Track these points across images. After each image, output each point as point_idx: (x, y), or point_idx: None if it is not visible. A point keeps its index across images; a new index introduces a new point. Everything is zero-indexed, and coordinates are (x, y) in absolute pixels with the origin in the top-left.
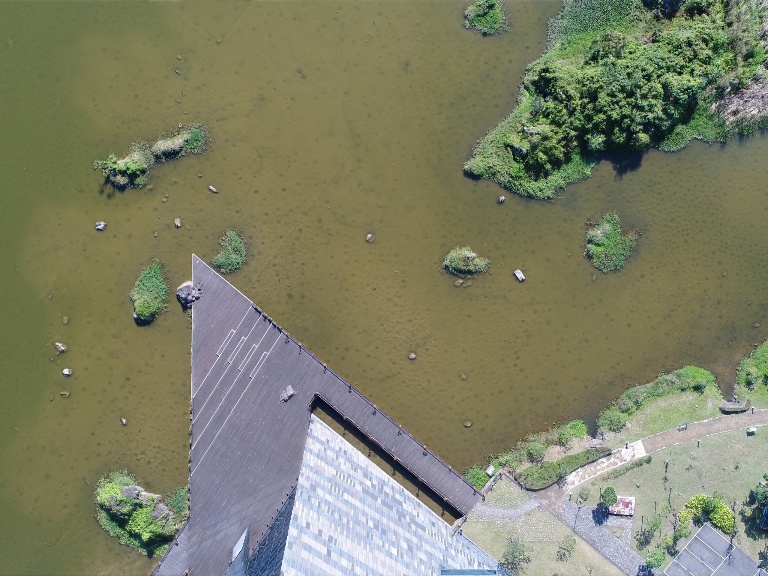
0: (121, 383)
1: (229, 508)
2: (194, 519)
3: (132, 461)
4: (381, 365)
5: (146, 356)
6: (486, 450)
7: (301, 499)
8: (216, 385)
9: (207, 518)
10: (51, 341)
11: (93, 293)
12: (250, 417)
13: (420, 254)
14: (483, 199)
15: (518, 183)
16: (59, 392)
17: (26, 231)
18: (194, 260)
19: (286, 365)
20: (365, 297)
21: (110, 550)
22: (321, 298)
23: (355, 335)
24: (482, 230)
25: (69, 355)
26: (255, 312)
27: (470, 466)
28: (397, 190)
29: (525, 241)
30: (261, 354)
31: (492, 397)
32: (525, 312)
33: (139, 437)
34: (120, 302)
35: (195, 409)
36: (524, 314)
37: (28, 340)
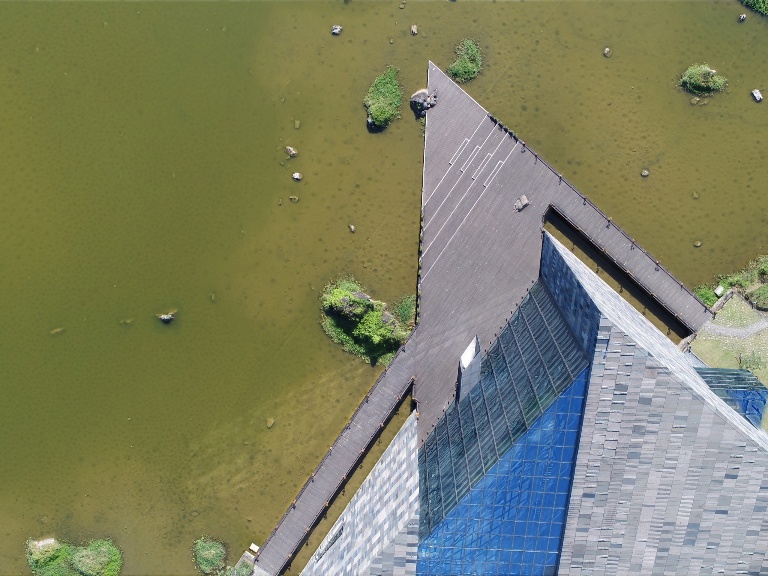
0: (351, 190)
1: (458, 316)
2: (422, 326)
3: (359, 268)
4: (613, 181)
5: (377, 163)
6: (715, 271)
7: (577, 275)
8: (449, 193)
9: (435, 325)
10: (282, 145)
11: (326, 98)
12: (483, 226)
13: (657, 70)
14: (723, 17)
15: (762, 0)
16: (288, 196)
17: (261, 33)
18: (430, 67)
19: (521, 174)
20: (600, 112)
21: (333, 357)
22: (555, 111)
23: (588, 150)
24: (721, 48)
25: (299, 160)
26: (490, 121)
27: (698, 286)
28: (637, 5)
29: (764, 61)
30: (496, 163)
31: (723, 217)
32: (761, 133)
33: (367, 245)
34: (353, 108)
35: (426, 217)
36: (759, 135)
37: (259, 143)
